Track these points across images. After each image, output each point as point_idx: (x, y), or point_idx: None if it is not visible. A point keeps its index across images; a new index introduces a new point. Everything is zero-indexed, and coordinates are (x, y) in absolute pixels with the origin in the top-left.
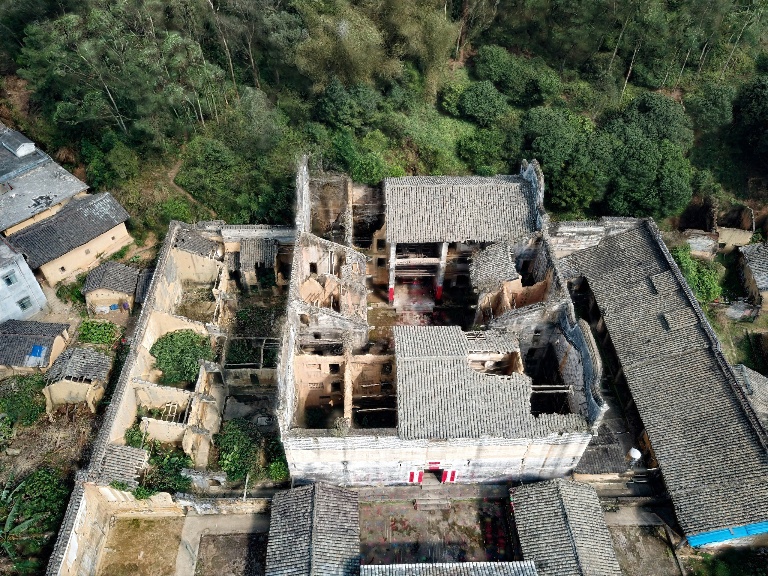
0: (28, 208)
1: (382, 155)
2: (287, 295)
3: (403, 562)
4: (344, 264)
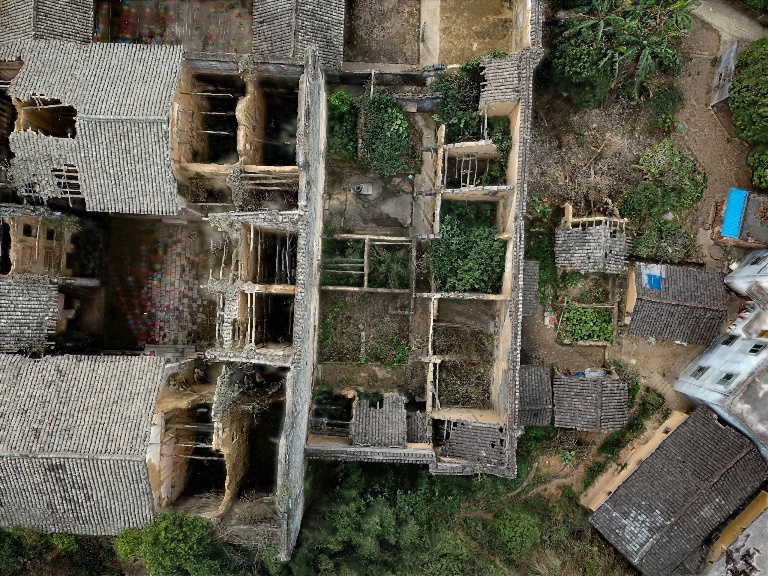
0: (759, 548)
1: (147, 569)
2: (345, 387)
3: (220, 27)
4: (239, 343)
